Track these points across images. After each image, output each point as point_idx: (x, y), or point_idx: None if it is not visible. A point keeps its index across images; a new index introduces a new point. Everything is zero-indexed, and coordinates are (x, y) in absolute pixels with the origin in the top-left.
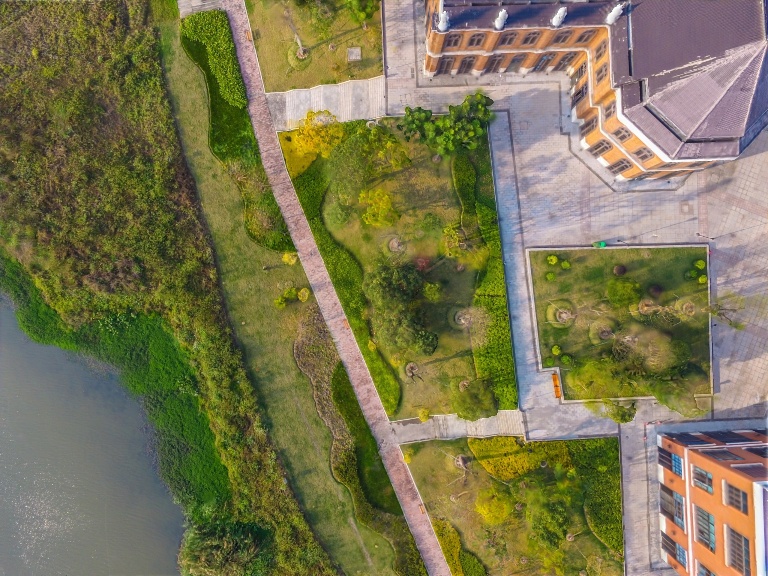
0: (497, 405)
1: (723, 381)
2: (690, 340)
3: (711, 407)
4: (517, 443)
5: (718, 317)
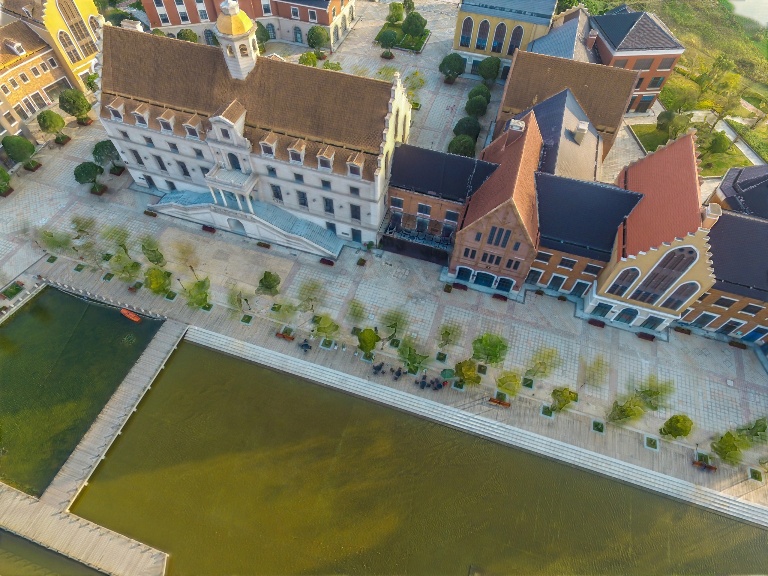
0: (764, 101)
1: (624, 130)
2: (652, 142)
3: (625, 122)
4: (714, 110)
5: (639, 153)
